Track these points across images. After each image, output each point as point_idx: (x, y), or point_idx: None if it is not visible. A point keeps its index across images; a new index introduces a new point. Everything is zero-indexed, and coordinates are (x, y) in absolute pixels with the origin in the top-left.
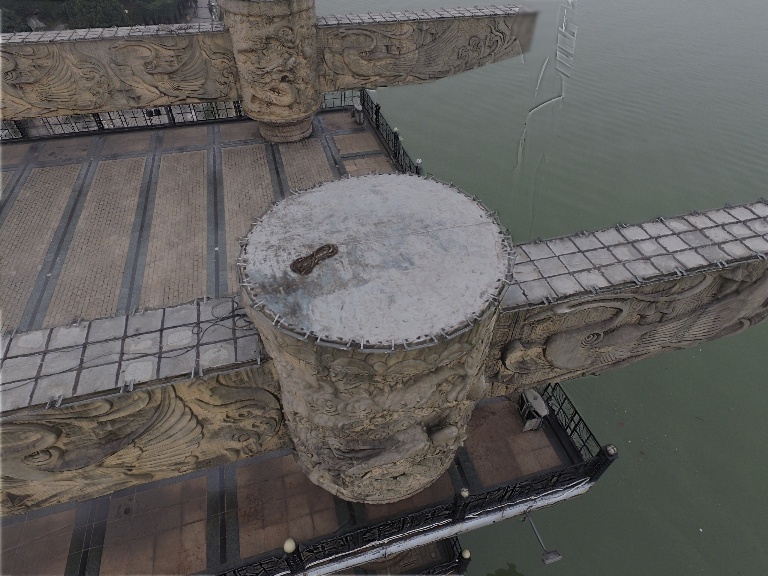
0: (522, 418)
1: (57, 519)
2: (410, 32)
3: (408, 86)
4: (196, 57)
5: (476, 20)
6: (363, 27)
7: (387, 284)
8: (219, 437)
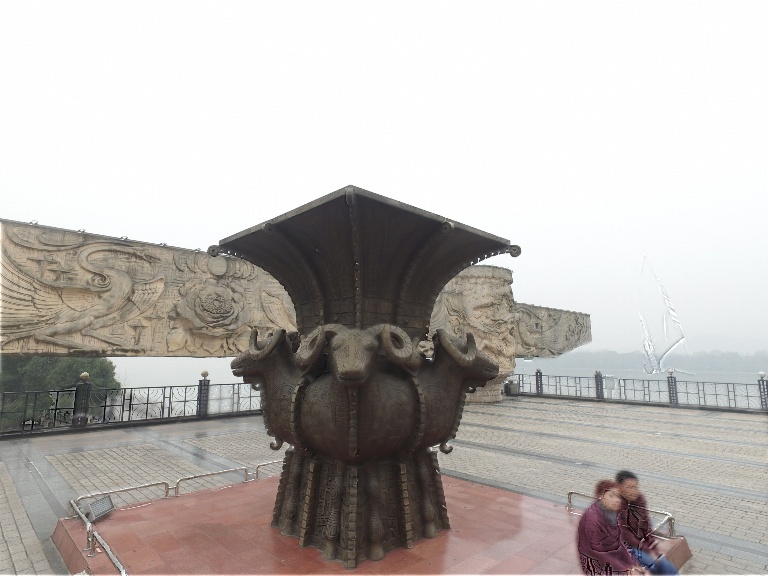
0: None
1: None
2: (546, 316)
3: (547, 359)
4: (441, 311)
5: (569, 314)
6: (526, 307)
7: None
8: None
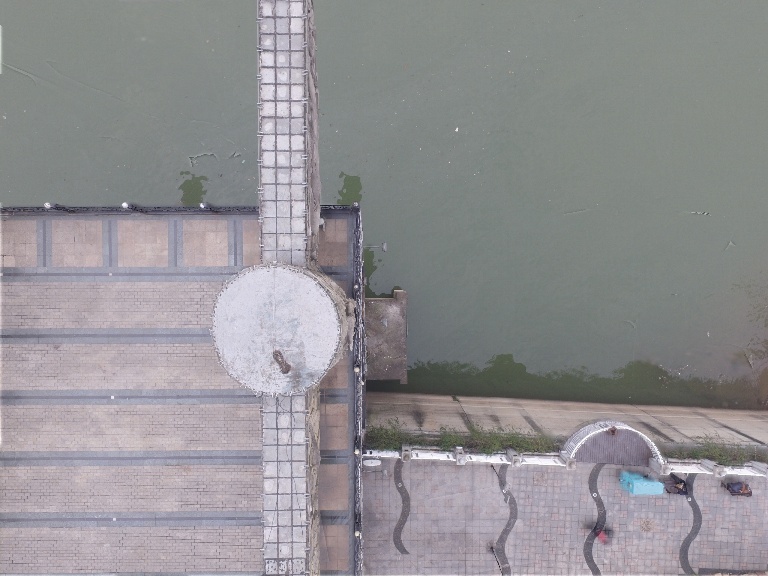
0: None
1: None
2: None
3: None
4: None
5: None
6: None
7: (306, 334)
8: (314, 401)
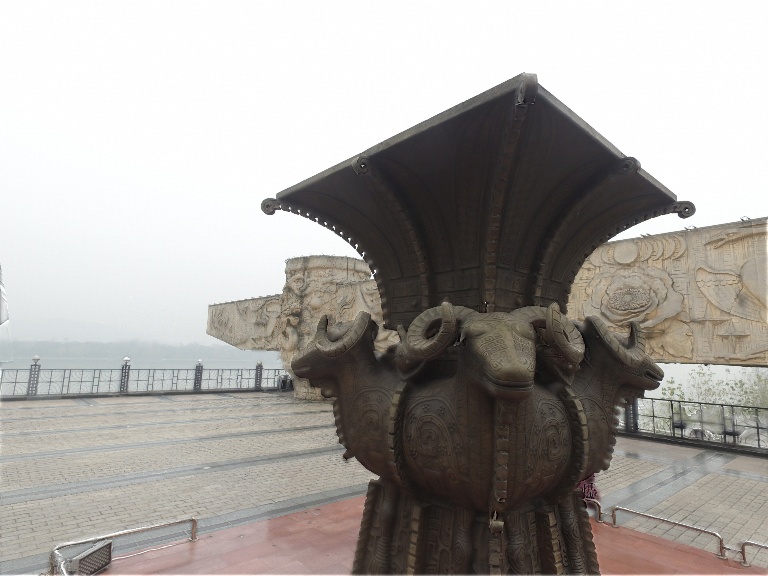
0: (288, 390)
1: None
2: None
3: None
4: None
5: None
6: None
7: None
8: None
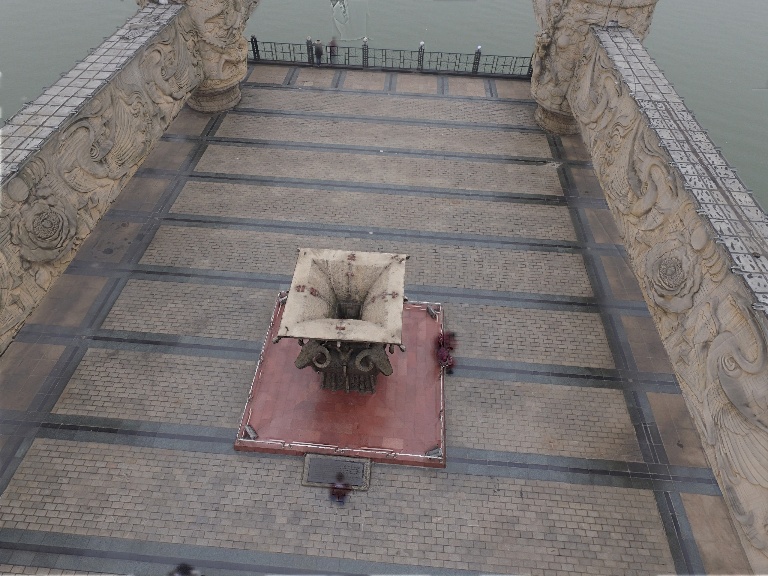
0: None
1: (589, 214)
2: None
3: (253, 13)
4: (180, 44)
5: None
6: None
7: None
8: None
